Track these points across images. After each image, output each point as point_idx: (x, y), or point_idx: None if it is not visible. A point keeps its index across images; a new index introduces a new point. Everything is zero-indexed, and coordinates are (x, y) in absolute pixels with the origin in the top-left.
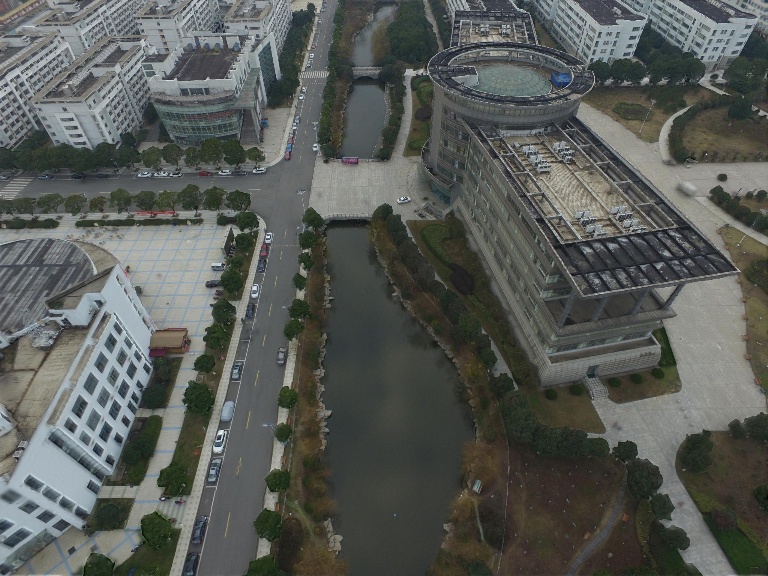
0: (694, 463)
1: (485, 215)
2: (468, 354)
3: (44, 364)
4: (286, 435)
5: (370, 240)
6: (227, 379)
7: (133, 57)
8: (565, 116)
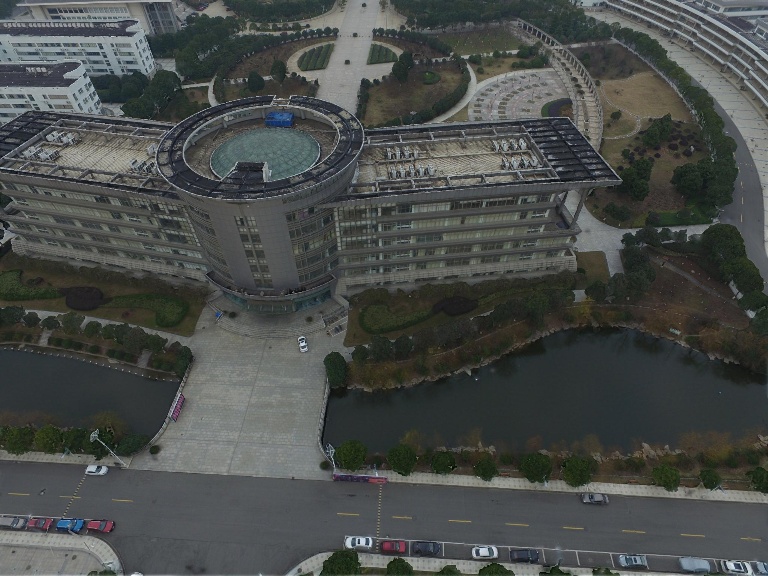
0: (629, 214)
1: (411, 251)
2: (547, 318)
3: None
4: None
5: (369, 394)
6: (648, 575)
7: None
8: None
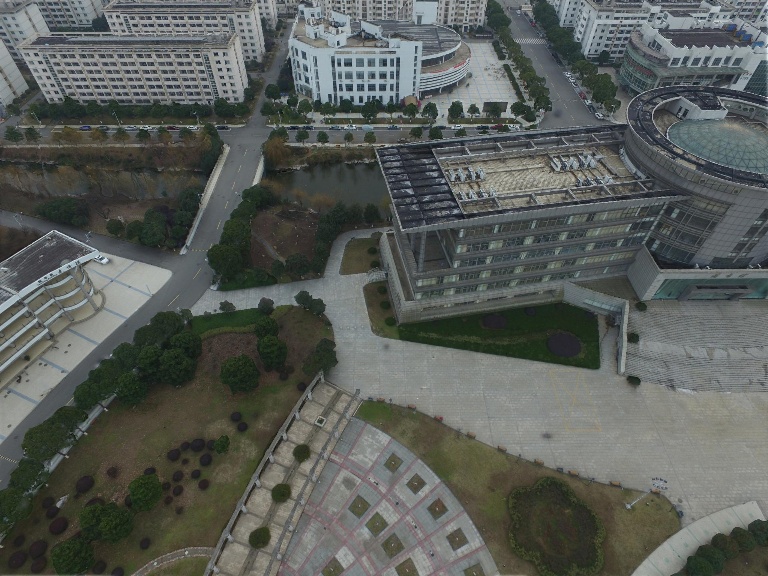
0: None
1: None
2: None
3: (367, 47)
4: (346, 137)
5: None
6: None
7: (689, 13)
8: (673, 185)
